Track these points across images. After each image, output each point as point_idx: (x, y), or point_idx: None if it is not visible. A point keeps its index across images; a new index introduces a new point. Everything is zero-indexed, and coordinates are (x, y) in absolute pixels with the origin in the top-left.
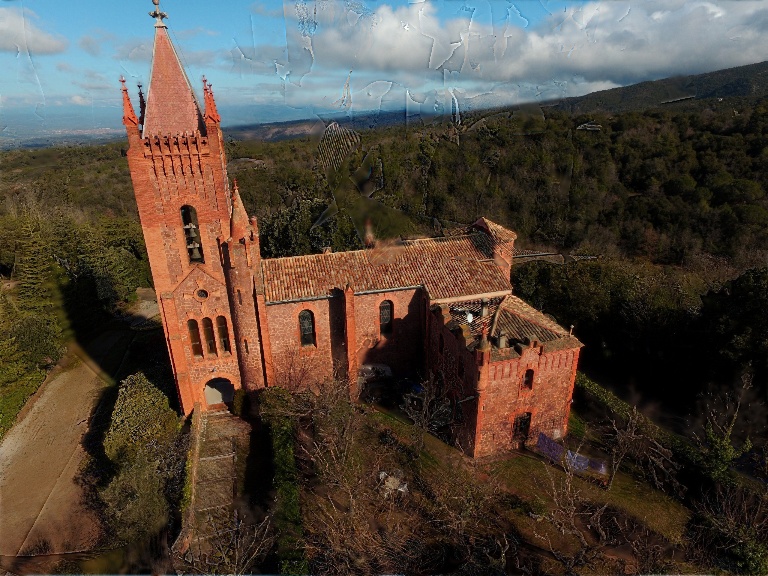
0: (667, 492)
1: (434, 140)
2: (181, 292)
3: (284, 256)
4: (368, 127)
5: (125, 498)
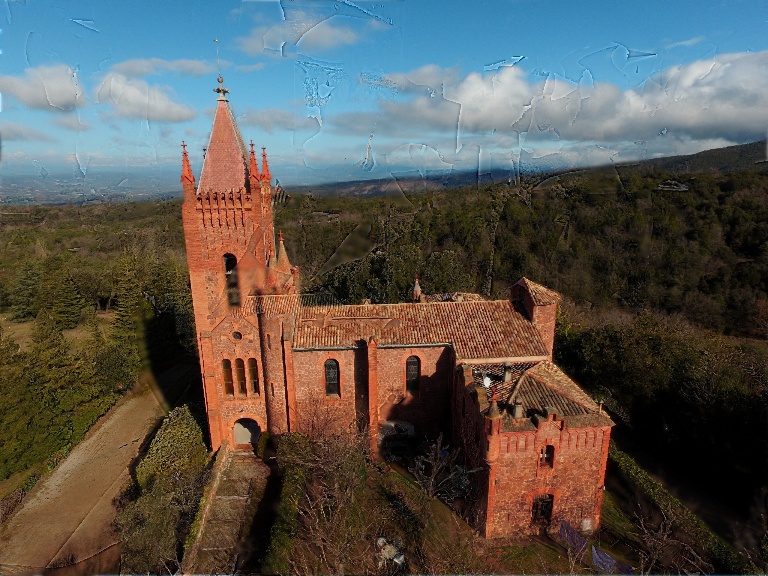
0: None
1: (506, 198)
2: (218, 333)
3: None
4: (442, 185)
5: (136, 525)
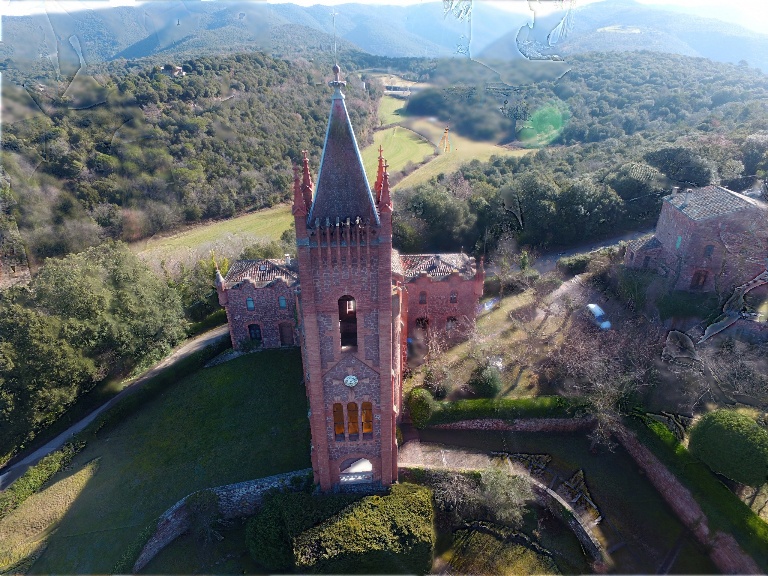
0: None
1: None
2: None
3: (46, 387)
4: None
5: None
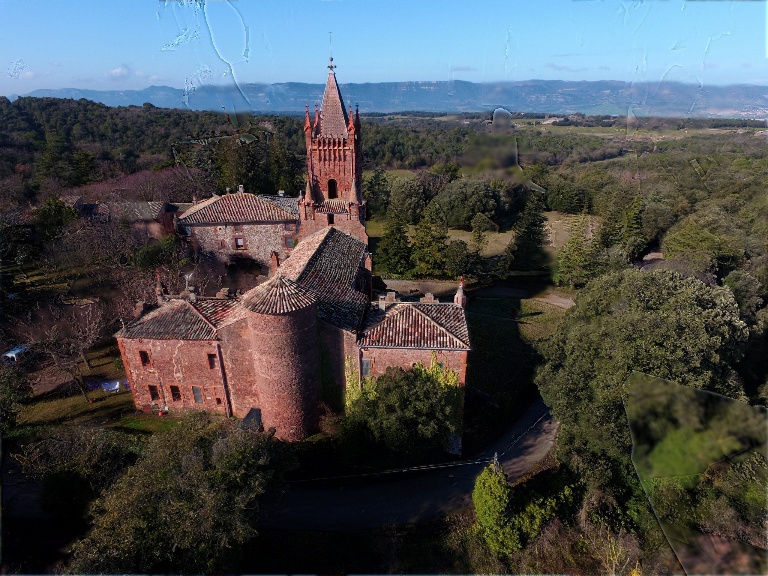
0: None
1: None
2: None
3: None
4: None
5: None
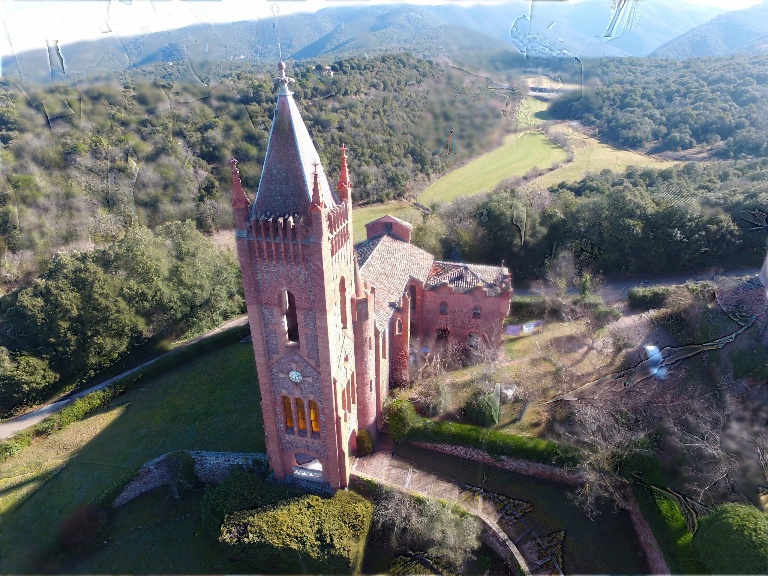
0: (551, 319)
1: (89, 146)
2: None
3: (101, 335)
4: None
5: None
